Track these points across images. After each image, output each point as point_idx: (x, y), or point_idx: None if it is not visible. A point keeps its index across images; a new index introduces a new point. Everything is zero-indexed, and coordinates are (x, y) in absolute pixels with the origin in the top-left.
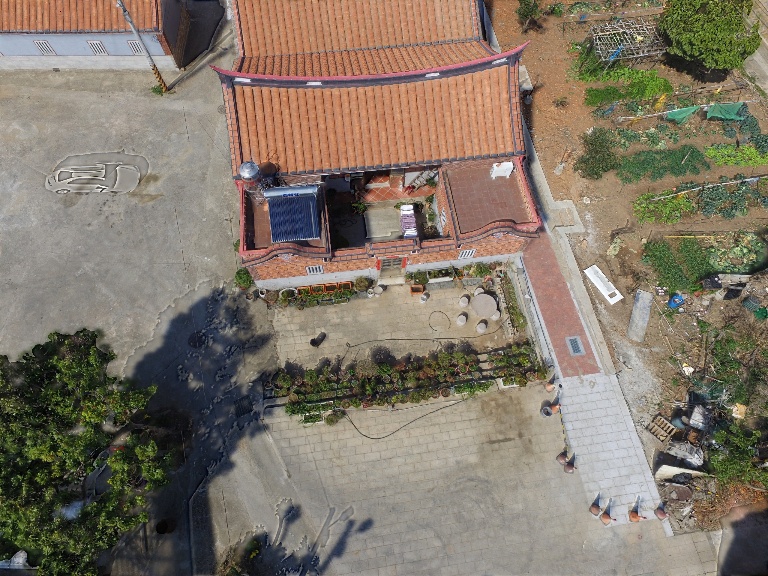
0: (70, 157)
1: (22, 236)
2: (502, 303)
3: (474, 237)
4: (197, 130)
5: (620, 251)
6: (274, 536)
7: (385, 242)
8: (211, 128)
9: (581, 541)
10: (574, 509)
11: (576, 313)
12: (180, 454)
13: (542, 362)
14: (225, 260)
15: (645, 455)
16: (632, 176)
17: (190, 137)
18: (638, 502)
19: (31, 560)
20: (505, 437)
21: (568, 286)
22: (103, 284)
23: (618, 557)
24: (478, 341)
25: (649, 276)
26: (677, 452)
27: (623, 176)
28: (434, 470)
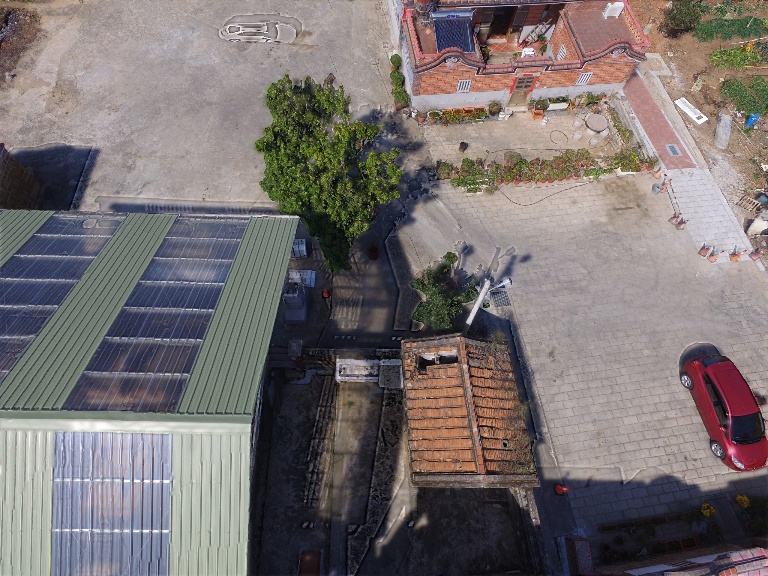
0: (235, 16)
1: (208, 70)
2: (610, 122)
3: (597, 54)
4: (337, 1)
5: (702, 87)
6: (456, 264)
7: (526, 57)
8: (348, 0)
9: (694, 272)
10: (687, 252)
11: (671, 129)
12: None
13: (649, 159)
14: (378, 91)
15: (737, 221)
16: (706, 37)
17: (332, 6)
18: (736, 249)
19: (316, 221)
20: (627, 206)
21: (662, 112)
22: None
23: (724, 282)
24: (592, 151)
25: (728, 104)
26: (763, 216)
27: (699, 37)
28: (574, 226)
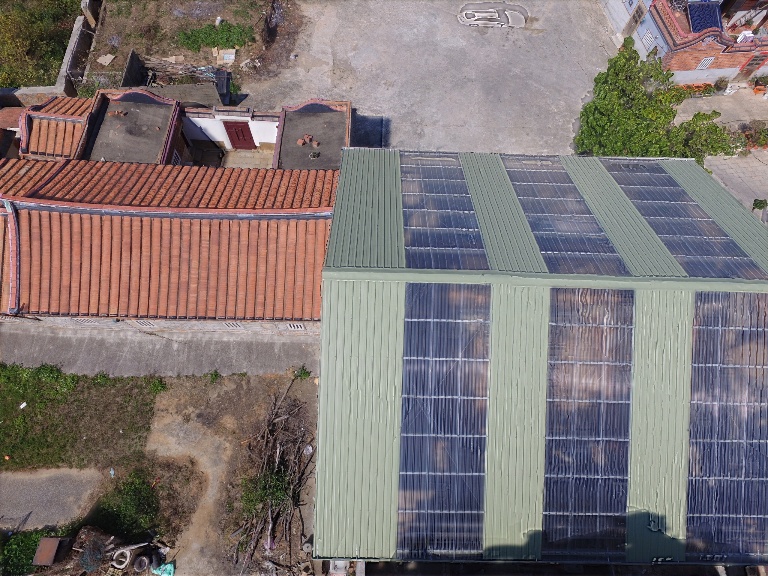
0: (468, 4)
1: (460, 51)
2: None
3: None
4: None
5: None
6: None
7: None
8: None
9: None
10: None
11: None
12: None
13: None
14: None
15: None
16: None
17: None
18: None
19: None
20: None
21: None
22: (532, 81)
23: None
24: None
25: None
26: None
27: None
28: None
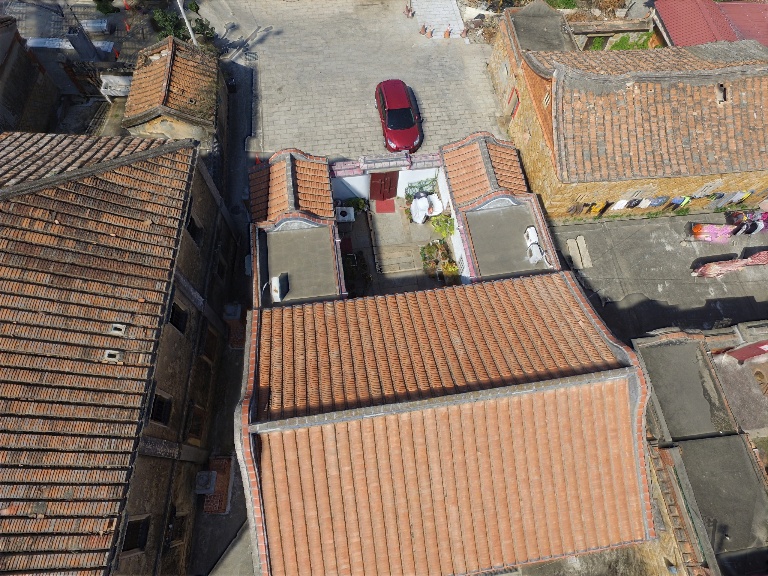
0: None
1: None
2: None
3: None
4: None
5: None
6: (222, 35)
7: None
8: None
9: (412, 44)
10: (410, 32)
11: None
12: (165, 3)
13: None
14: None
15: (460, 14)
16: None
17: None
18: (451, 31)
19: None
20: (372, 3)
21: None
22: None
23: (433, 50)
24: None
25: None
26: None
27: None
28: (325, 14)
